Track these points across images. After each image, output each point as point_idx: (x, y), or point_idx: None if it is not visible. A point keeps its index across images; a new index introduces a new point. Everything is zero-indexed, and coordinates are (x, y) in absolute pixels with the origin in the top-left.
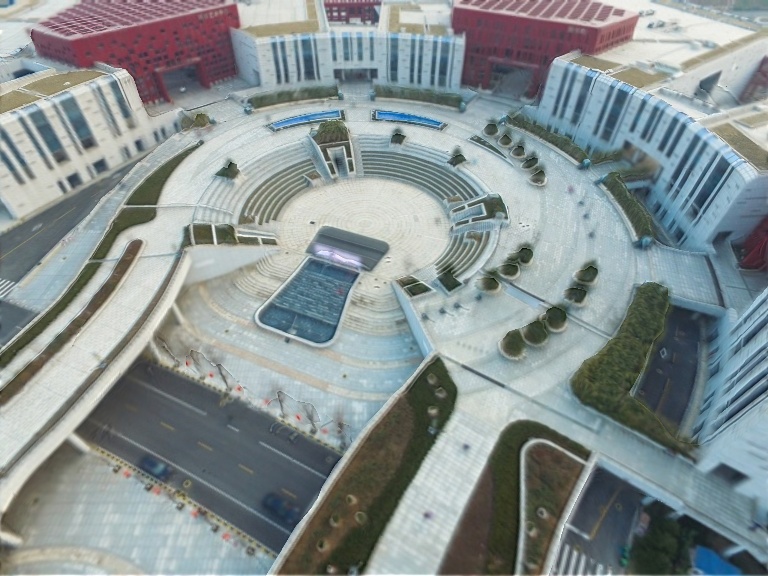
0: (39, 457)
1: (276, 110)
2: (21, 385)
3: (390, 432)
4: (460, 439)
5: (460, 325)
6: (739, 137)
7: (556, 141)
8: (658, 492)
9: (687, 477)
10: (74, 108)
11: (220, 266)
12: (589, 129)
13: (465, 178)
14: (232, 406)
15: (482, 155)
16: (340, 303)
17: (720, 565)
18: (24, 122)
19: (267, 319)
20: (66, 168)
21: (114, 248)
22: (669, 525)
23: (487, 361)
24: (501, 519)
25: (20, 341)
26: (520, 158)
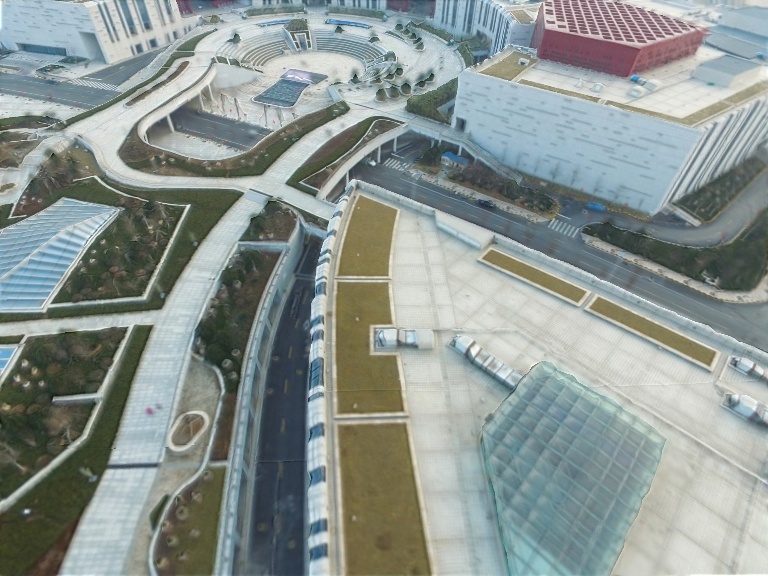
0: (157, 117)
1: (263, 18)
2: (143, 97)
3: (315, 115)
4: (348, 119)
5: (358, 94)
6: (523, 14)
7: (437, 32)
8: (431, 132)
9: (446, 130)
10: (141, 1)
11: (232, 80)
12: (460, 28)
13: (377, 48)
14: (241, 124)
15: (391, 39)
16: (298, 95)
17: (453, 156)
18: (116, 3)
19: (258, 101)
20: (135, 39)
21: (174, 64)
22: (435, 146)
23: (368, 103)
24: (358, 132)
25: (137, 86)
26: (413, 40)
